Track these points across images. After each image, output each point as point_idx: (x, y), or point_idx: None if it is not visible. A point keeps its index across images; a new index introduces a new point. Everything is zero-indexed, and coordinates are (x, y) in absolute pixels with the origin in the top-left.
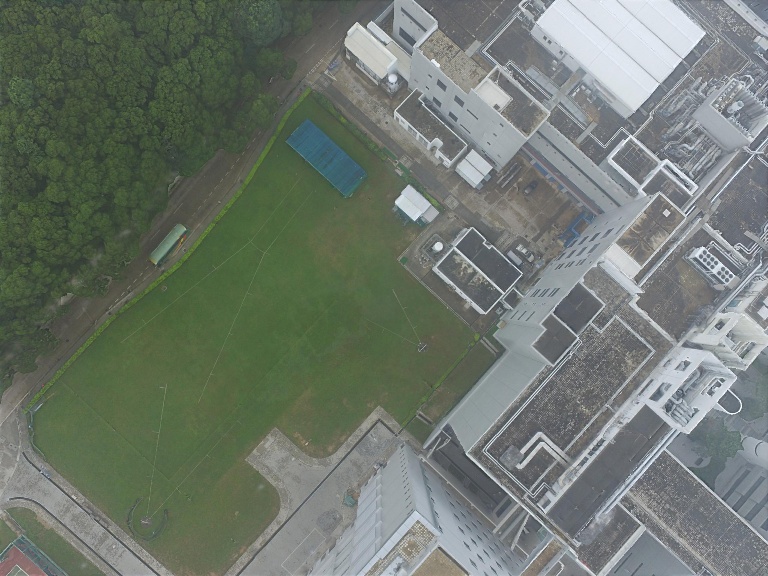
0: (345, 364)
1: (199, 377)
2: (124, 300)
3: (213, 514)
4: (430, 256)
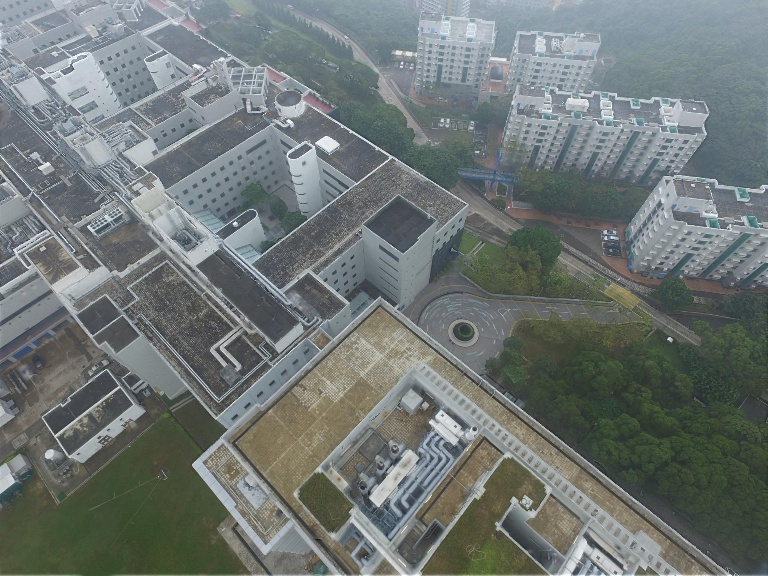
0: (158, 575)
1: None
2: None
3: None
4: (62, 464)
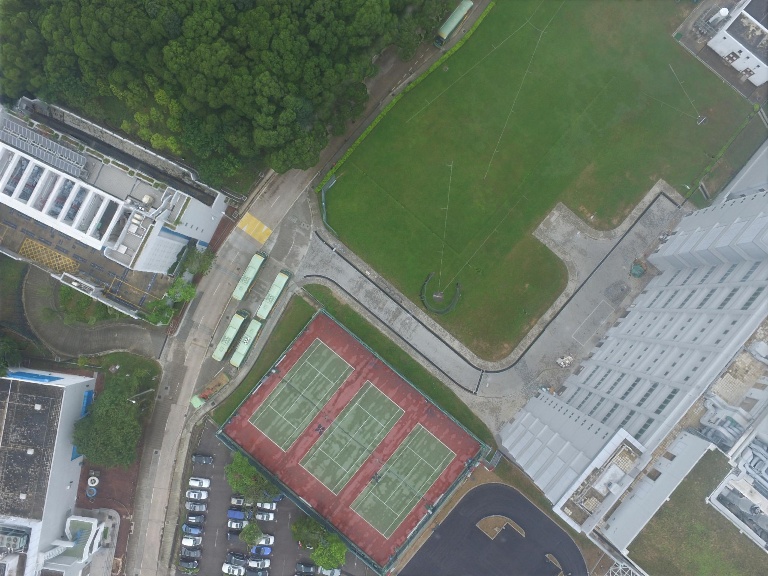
0: (626, 138)
1: (484, 154)
2: (407, 81)
3: (504, 287)
4: (711, 26)
